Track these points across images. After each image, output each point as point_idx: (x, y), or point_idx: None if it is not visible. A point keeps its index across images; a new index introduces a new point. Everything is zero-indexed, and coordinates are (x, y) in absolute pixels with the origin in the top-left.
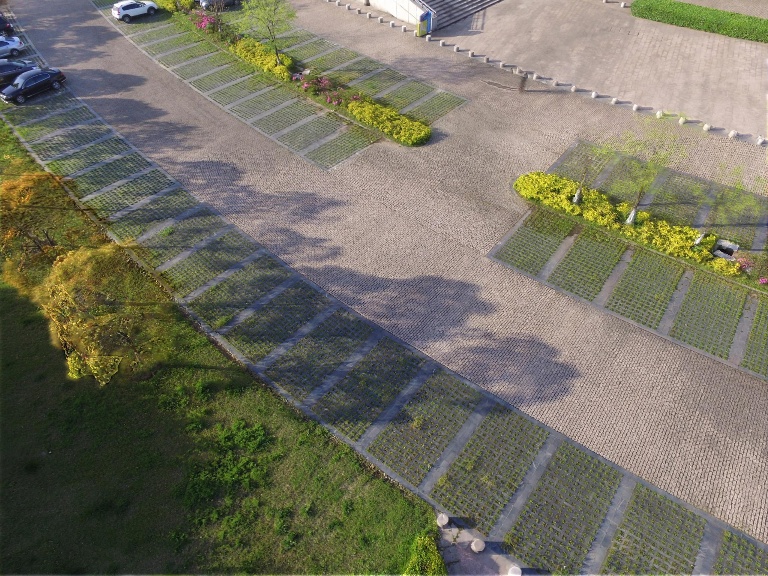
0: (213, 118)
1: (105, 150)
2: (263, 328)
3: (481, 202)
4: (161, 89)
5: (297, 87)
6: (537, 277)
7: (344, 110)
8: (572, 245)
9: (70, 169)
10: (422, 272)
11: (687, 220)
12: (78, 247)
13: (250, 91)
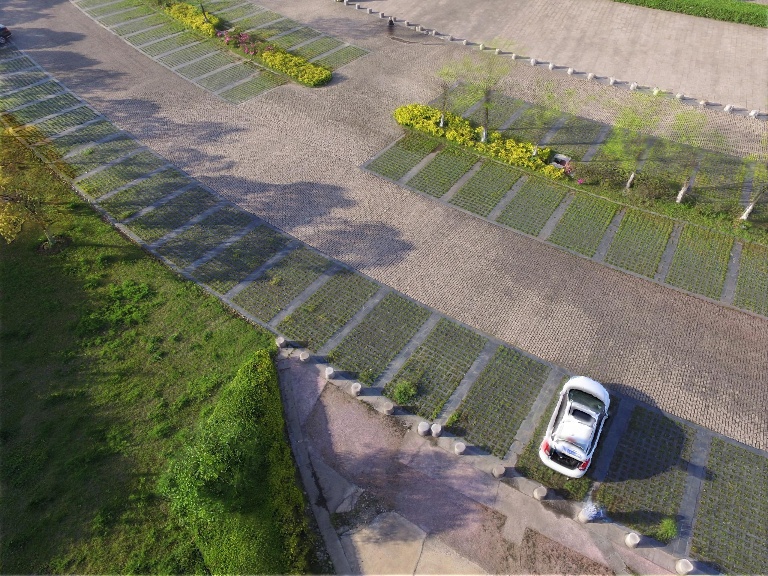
0: (141, 66)
1: (41, 91)
2: (160, 220)
3: (364, 128)
4: (97, 43)
5: (221, 41)
6: (398, 182)
7: (259, 59)
8: (433, 159)
9: (7, 106)
10: (303, 179)
11: (534, 140)
12: (8, 163)
13: (178, 45)
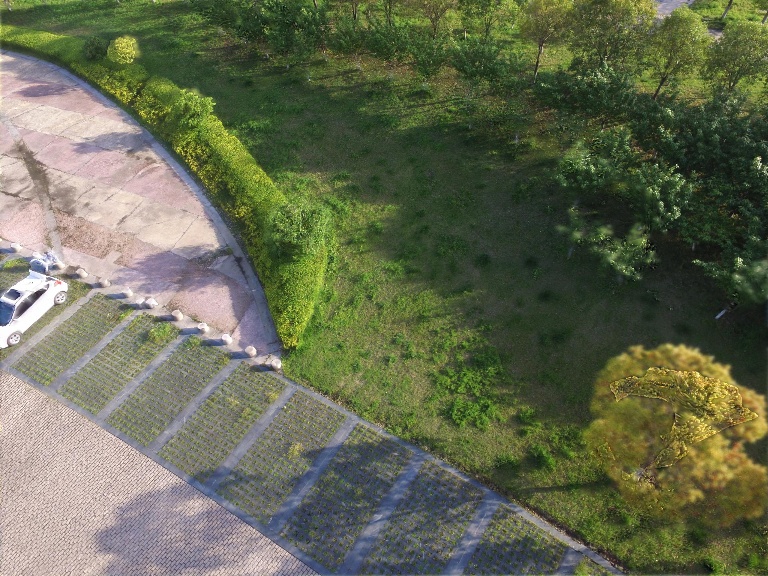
0: None
1: None
2: (516, 567)
3: None
4: None
5: None
6: None
7: None
8: None
9: None
10: None
11: None
12: None
13: None
